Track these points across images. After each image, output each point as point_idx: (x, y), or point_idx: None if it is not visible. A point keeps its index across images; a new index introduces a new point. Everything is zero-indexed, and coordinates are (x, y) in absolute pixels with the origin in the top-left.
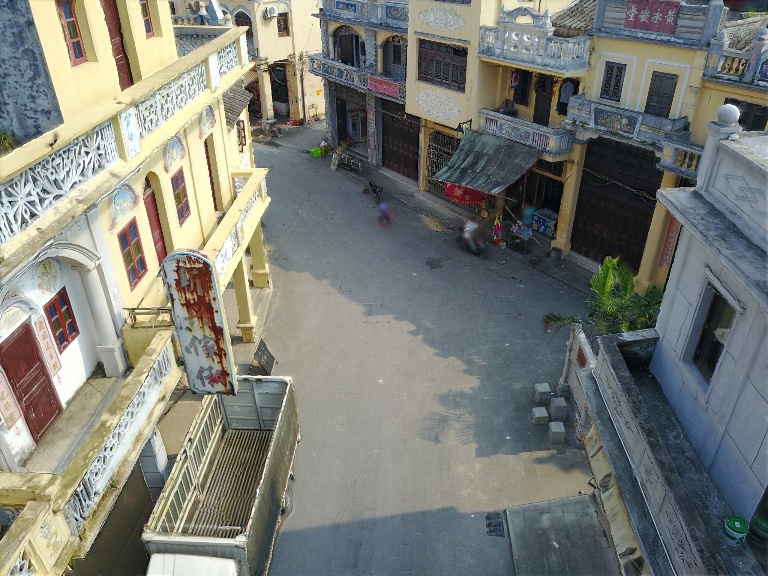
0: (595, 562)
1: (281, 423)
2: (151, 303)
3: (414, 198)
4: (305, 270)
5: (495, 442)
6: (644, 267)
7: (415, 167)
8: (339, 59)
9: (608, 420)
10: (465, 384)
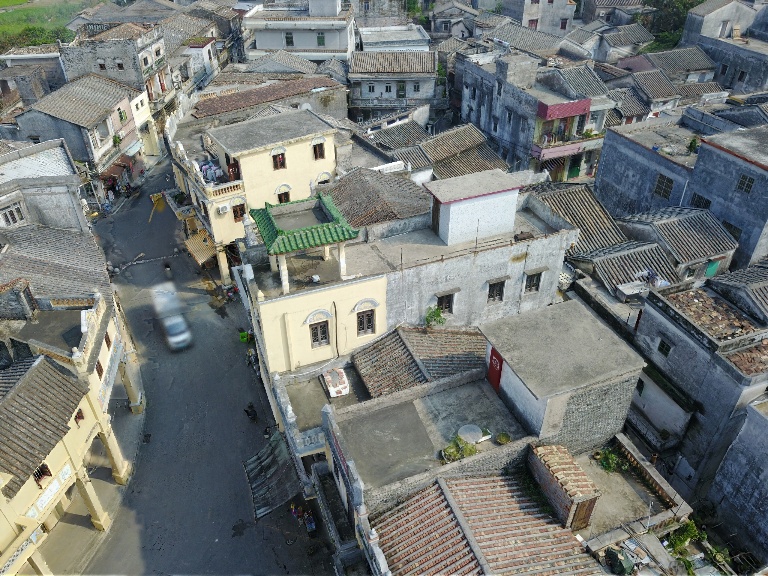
0: None
1: None
2: None
3: None
4: (144, 512)
5: None
6: None
7: None
8: None
9: None
10: None
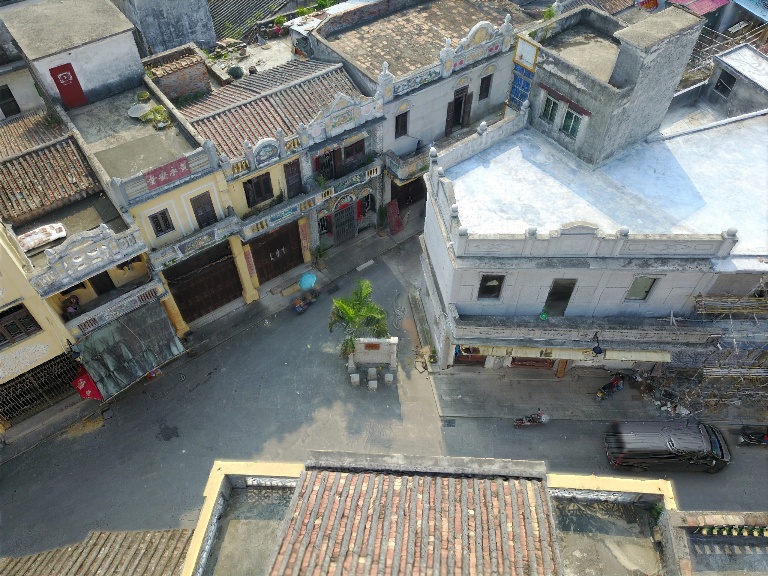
0: (468, 382)
1: None
2: None
3: (13, 444)
4: None
5: (391, 414)
6: (248, 287)
7: None
8: None
9: (488, 340)
10: (338, 425)
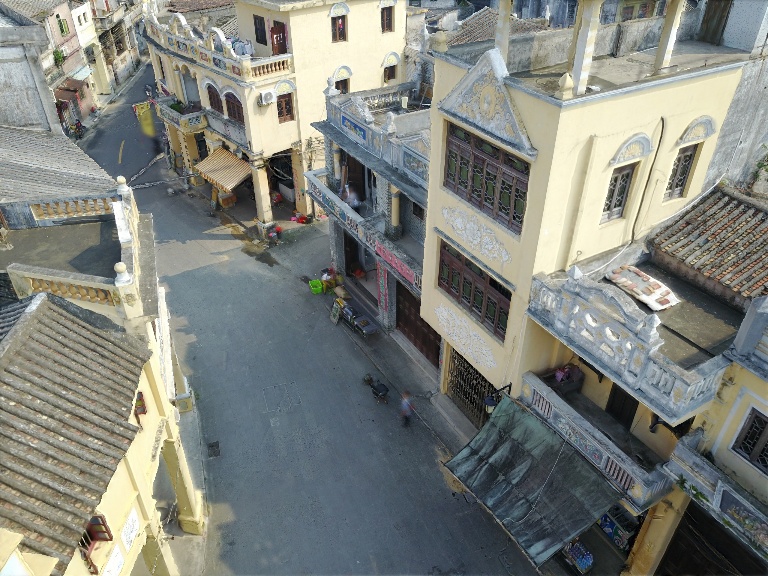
0: None
1: None
2: None
3: (430, 406)
4: None
5: None
6: None
7: (436, 353)
8: (347, 181)
9: None
10: None
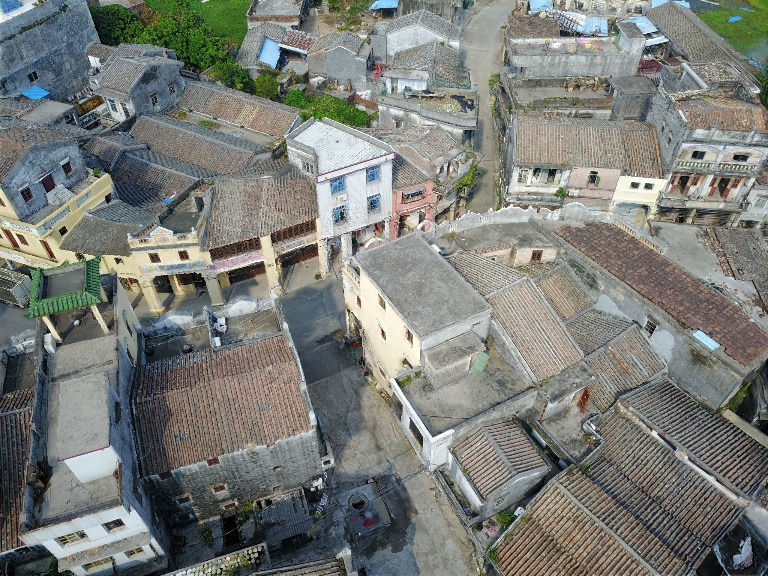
0: None
1: (0, 288)
2: (6, 244)
3: None
4: None
5: None
6: None
7: None
8: None
9: None
10: None
